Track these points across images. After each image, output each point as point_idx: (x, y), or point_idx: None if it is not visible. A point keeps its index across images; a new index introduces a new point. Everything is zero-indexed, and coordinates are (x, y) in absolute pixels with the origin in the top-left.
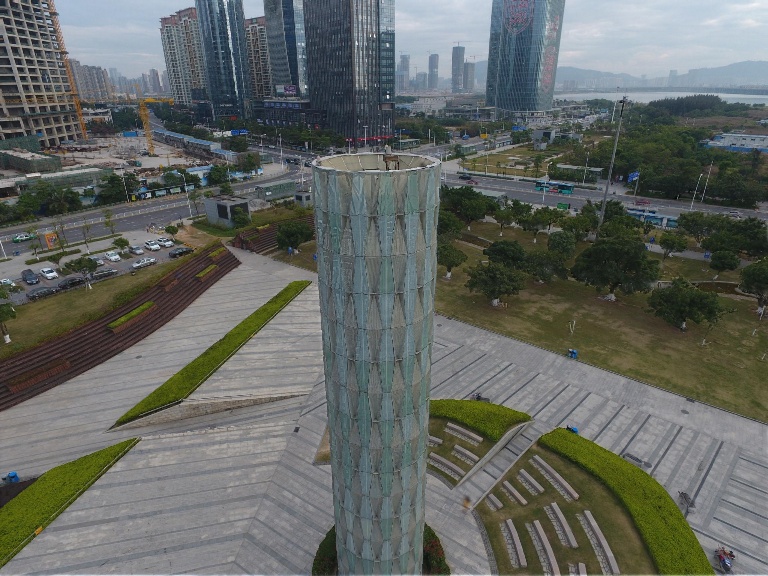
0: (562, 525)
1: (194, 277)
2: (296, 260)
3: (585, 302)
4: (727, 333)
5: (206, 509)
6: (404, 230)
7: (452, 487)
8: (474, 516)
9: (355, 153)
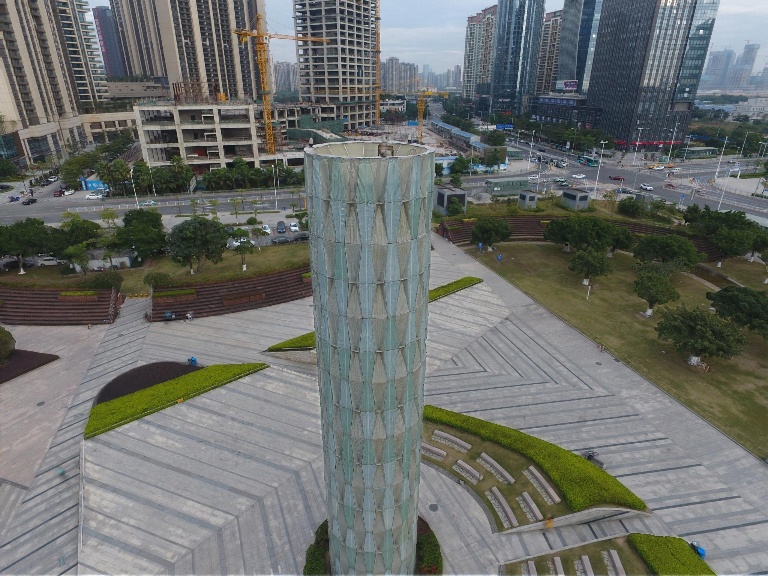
0: None
1: None
2: (485, 257)
3: None
4: None
5: (281, 438)
6: (357, 219)
7: (495, 531)
8: (499, 572)
9: (609, 157)
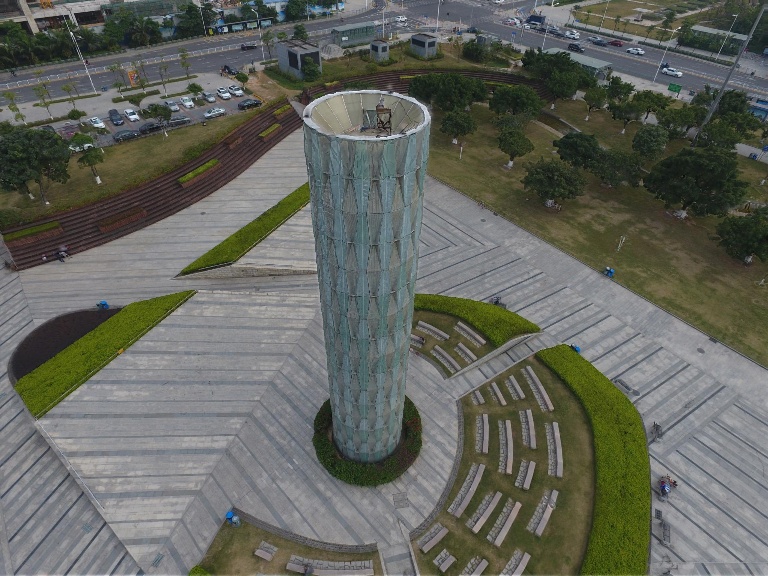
0: (529, 429)
1: (257, 136)
2: None
3: (649, 216)
4: None
5: (243, 357)
6: (380, 193)
7: (446, 378)
8: (457, 405)
9: None
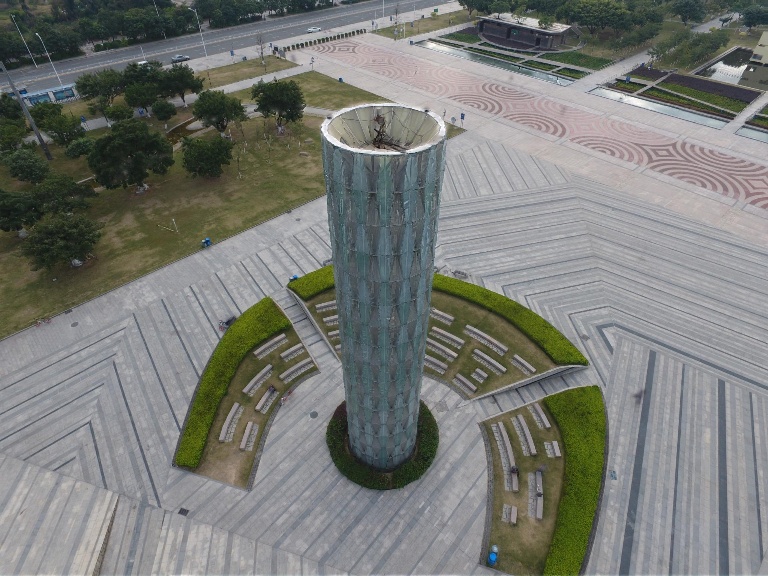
0: None
1: None
2: None
3: (135, 203)
4: (236, 161)
5: None
6: None
7: (318, 372)
8: None
9: None
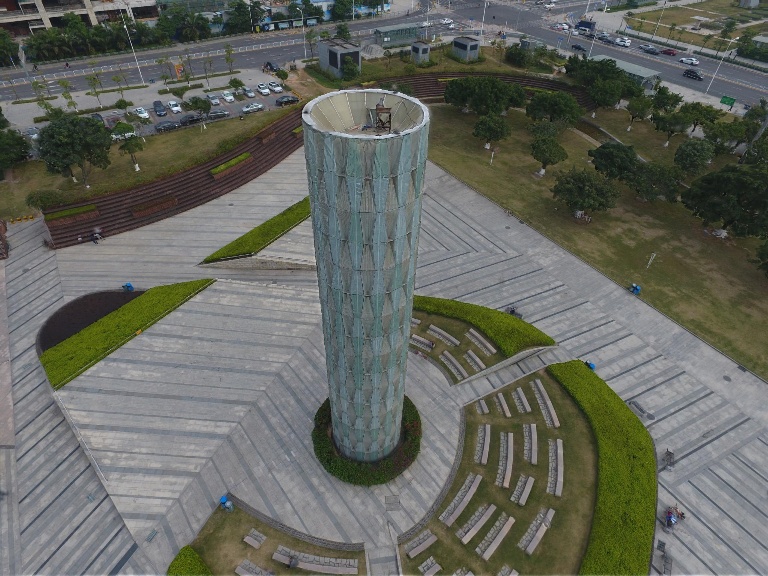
0: (532, 444)
1: (291, 132)
2: None
3: (685, 233)
4: None
5: (253, 347)
6: (373, 192)
7: (452, 384)
8: (460, 413)
9: None
